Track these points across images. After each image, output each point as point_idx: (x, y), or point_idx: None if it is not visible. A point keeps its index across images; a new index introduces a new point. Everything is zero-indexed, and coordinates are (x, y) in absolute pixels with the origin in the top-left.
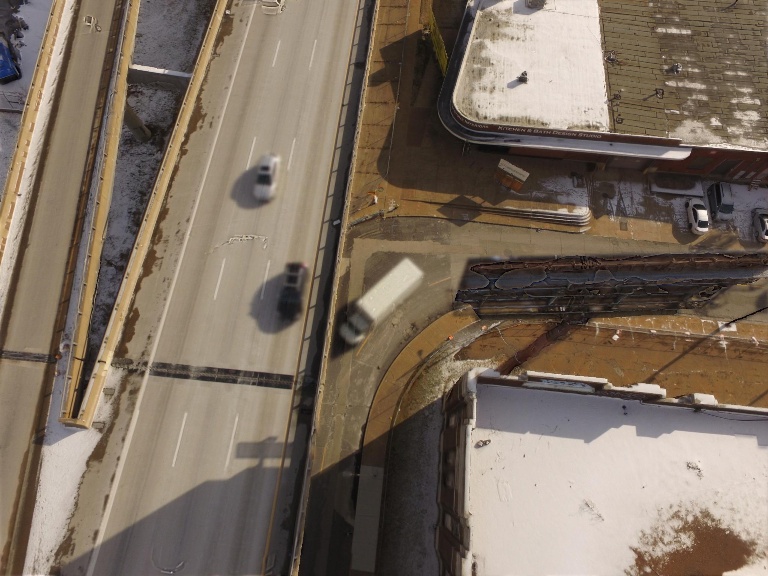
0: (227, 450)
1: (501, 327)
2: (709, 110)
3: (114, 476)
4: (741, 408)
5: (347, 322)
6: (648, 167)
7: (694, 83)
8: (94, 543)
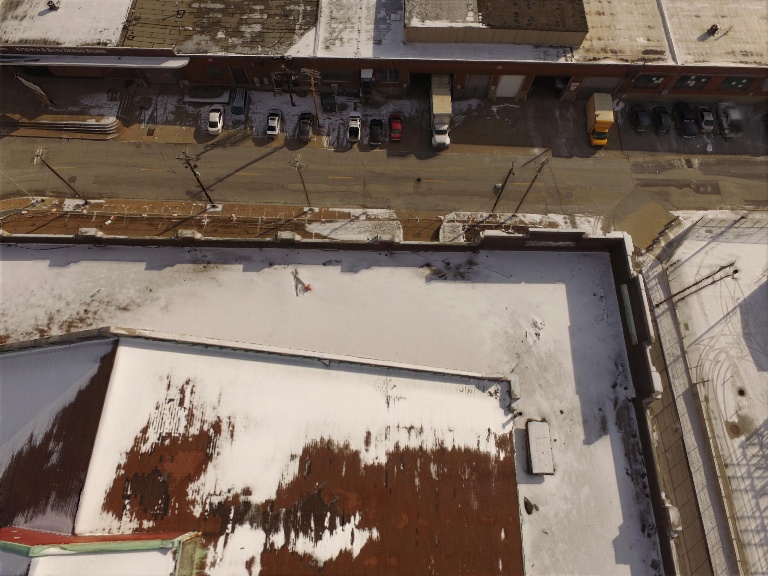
0: None
1: (4, 220)
2: (219, 25)
3: None
4: (24, 235)
5: None
6: (179, 80)
7: (215, 4)
8: None
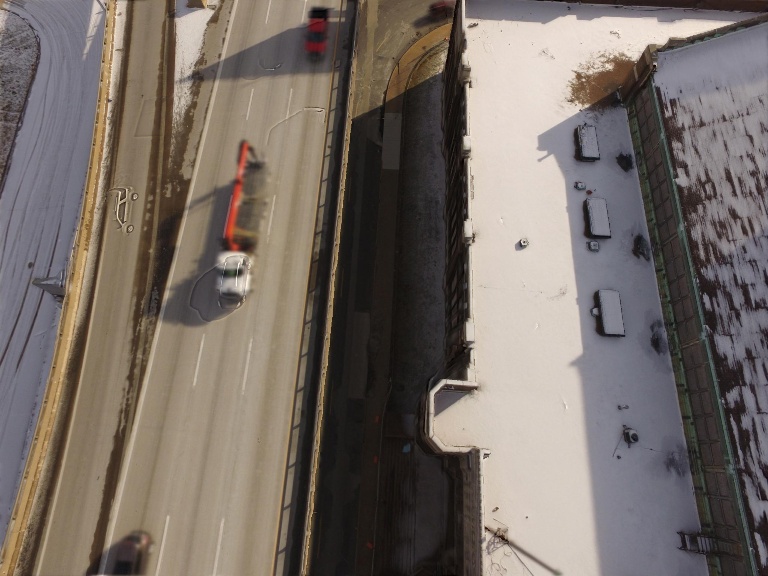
0: (302, 14)
1: None
2: None
3: (227, 29)
4: None
5: (368, 32)
6: None
7: None
8: (219, 59)
